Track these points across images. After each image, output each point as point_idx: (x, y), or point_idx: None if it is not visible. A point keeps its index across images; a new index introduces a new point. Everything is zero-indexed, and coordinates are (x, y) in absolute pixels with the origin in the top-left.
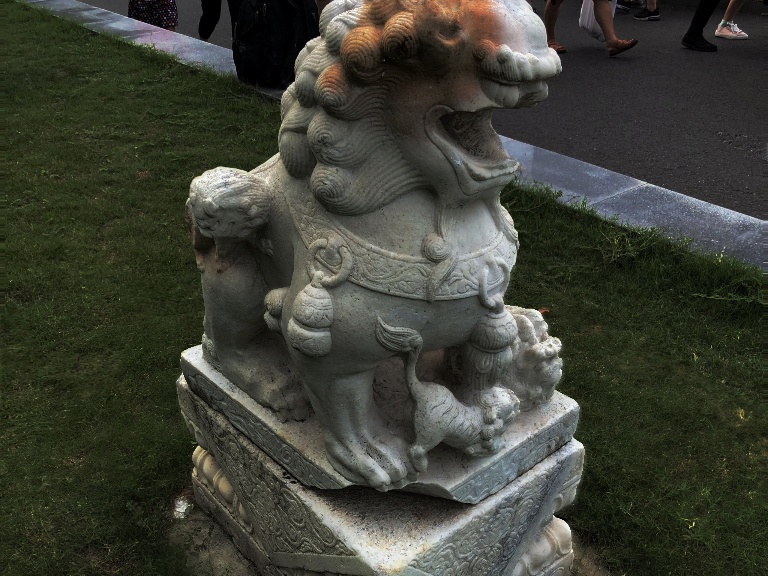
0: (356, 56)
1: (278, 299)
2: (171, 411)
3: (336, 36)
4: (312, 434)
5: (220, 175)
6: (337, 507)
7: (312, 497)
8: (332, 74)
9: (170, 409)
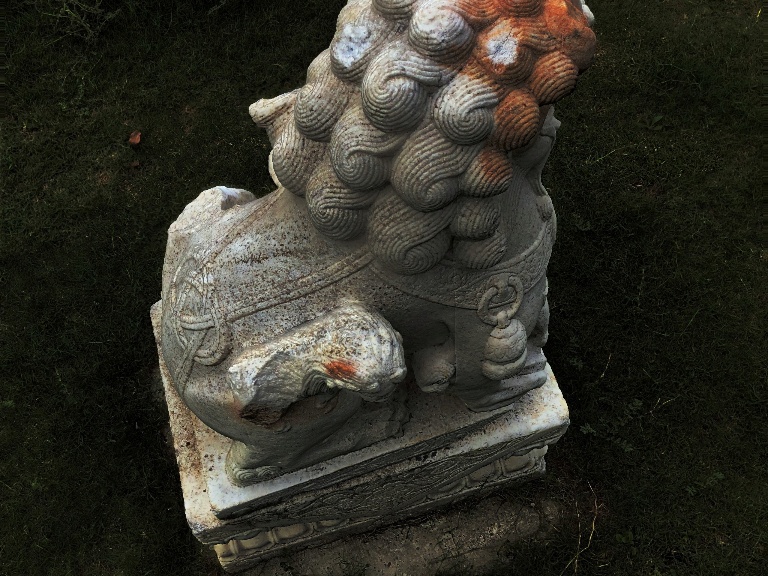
0: (534, 131)
1: (449, 367)
2: (74, 569)
3: (485, 127)
4: (432, 415)
5: (374, 344)
6: (482, 428)
7: (461, 445)
8: (497, 163)
9: (71, 570)
